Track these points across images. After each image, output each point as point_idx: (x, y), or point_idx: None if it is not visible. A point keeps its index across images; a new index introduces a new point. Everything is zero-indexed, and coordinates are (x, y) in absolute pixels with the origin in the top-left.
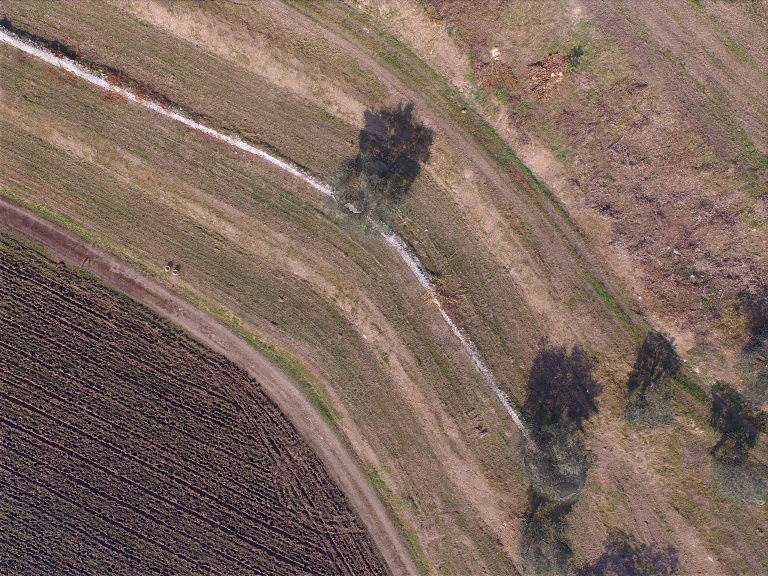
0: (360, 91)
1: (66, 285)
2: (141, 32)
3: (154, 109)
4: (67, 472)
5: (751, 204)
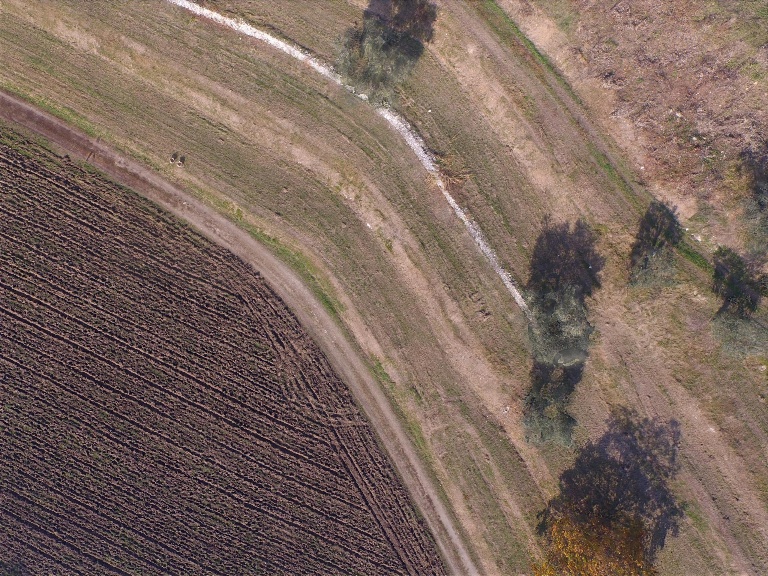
0: None
1: (71, 179)
2: None
3: None
4: (72, 365)
5: (753, 55)
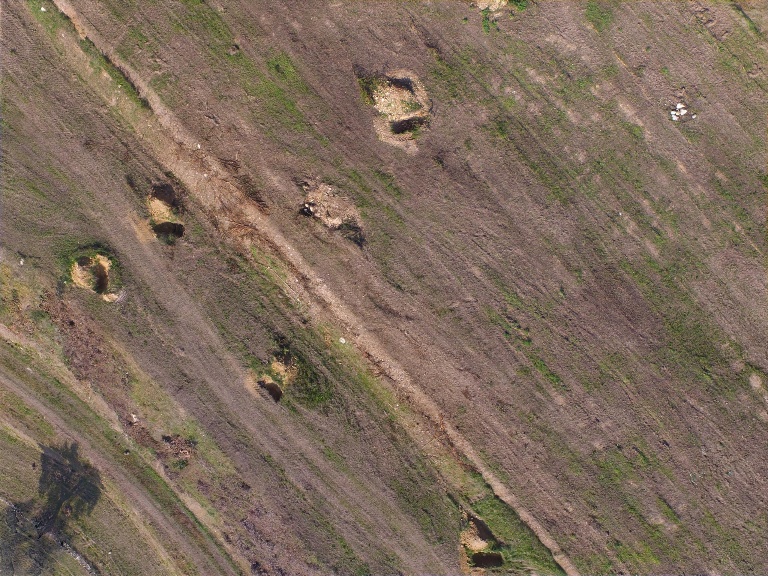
0: (28, 427)
1: None
2: None
3: None
4: None
5: None
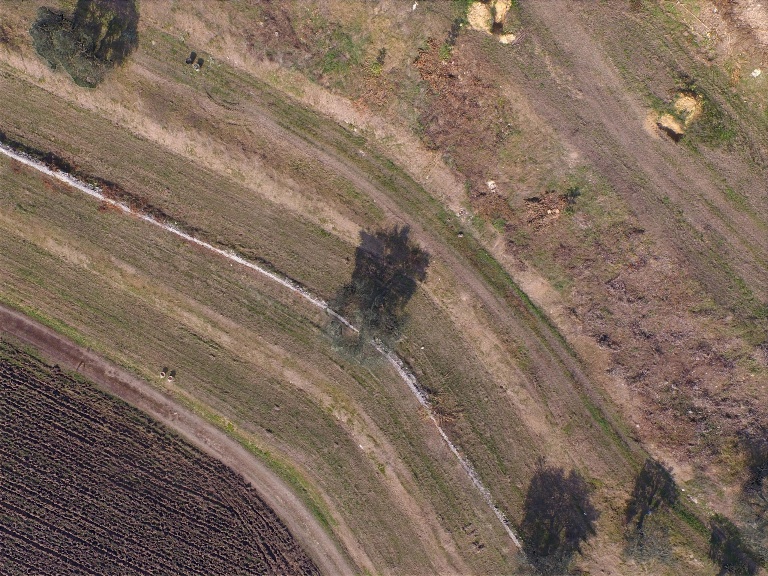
0: (356, 213)
1: (61, 389)
2: (136, 146)
3: (149, 220)
4: None
5: (750, 351)
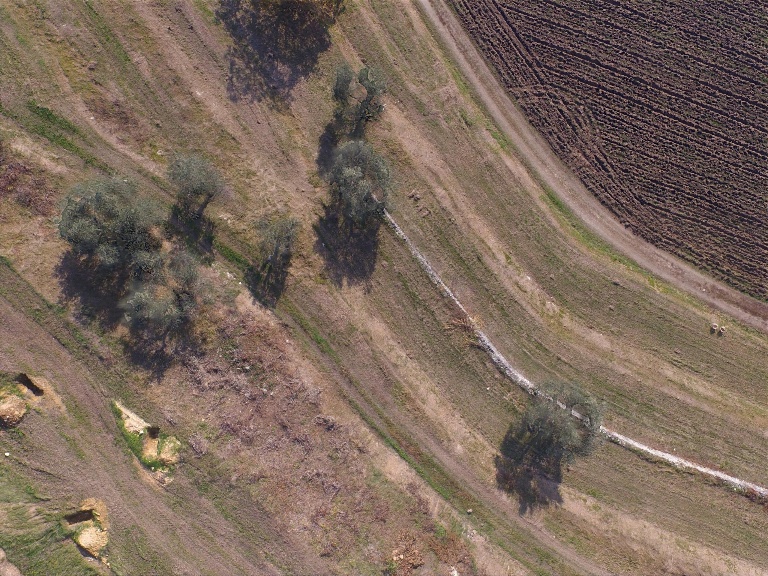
0: (571, 523)
1: None
2: None
3: (758, 487)
4: None
5: (211, 446)
